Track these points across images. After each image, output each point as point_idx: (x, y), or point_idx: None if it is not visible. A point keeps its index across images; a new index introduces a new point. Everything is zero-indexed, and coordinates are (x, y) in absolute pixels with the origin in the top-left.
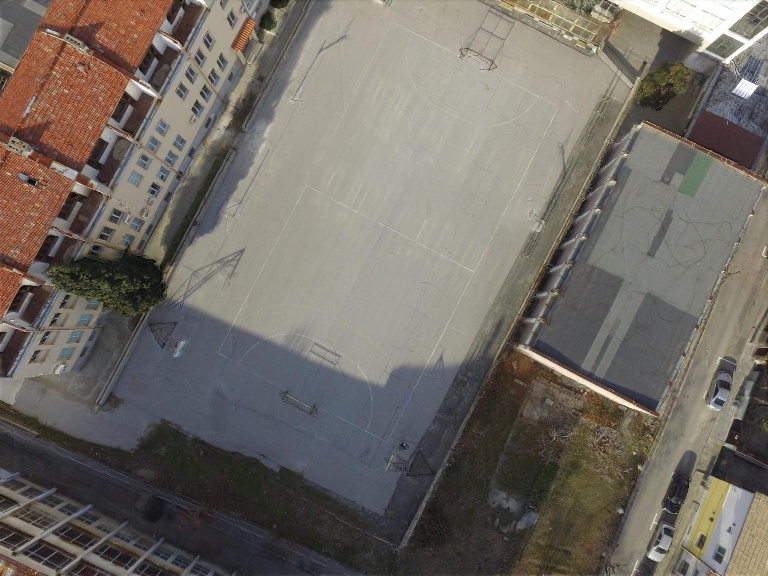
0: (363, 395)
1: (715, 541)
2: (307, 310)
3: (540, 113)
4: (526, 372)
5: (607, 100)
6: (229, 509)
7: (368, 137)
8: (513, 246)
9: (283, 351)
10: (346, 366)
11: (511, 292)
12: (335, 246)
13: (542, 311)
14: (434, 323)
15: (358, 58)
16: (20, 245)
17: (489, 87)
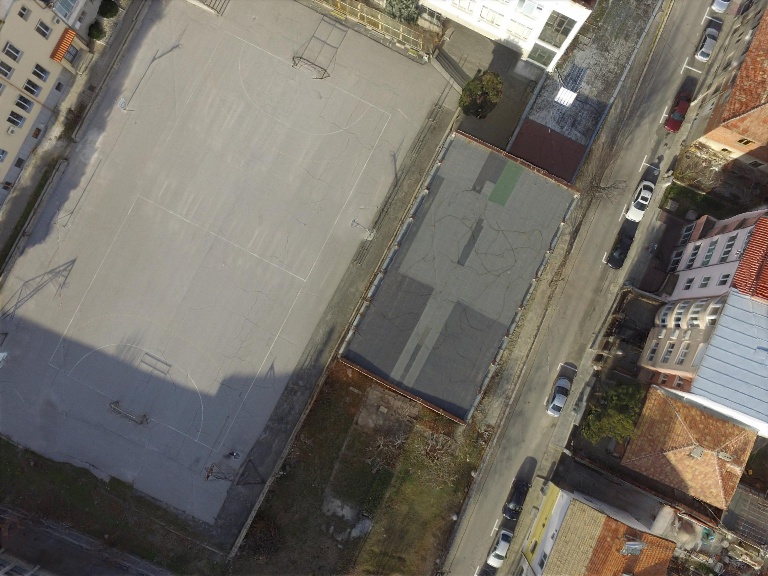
0: (194, 404)
1: (542, 547)
2: (138, 320)
3: (373, 121)
4: (361, 380)
5: (439, 108)
6: (59, 520)
7: (200, 146)
8: (344, 254)
9: (114, 361)
10: (177, 376)
11: (342, 300)
12: (166, 256)
13: (356, 320)
14: (265, 332)
15: (191, 67)
16: None
17: (322, 96)
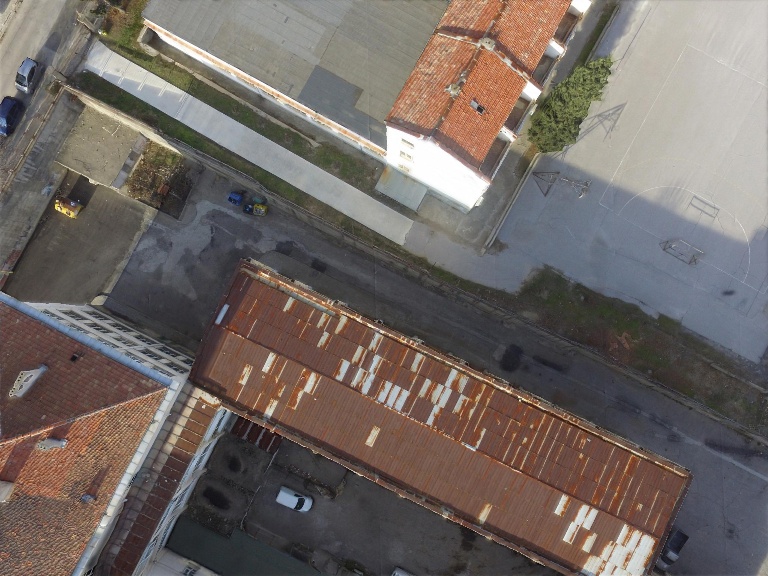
0: (741, 248)
1: None
2: (687, 164)
3: None
4: None
5: None
6: (608, 353)
7: None
8: None
9: (663, 203)
10: (725, 219)
11: None
12: (715, 103)
13: None
14: None
15: None
16: (528, 49)
17: None
